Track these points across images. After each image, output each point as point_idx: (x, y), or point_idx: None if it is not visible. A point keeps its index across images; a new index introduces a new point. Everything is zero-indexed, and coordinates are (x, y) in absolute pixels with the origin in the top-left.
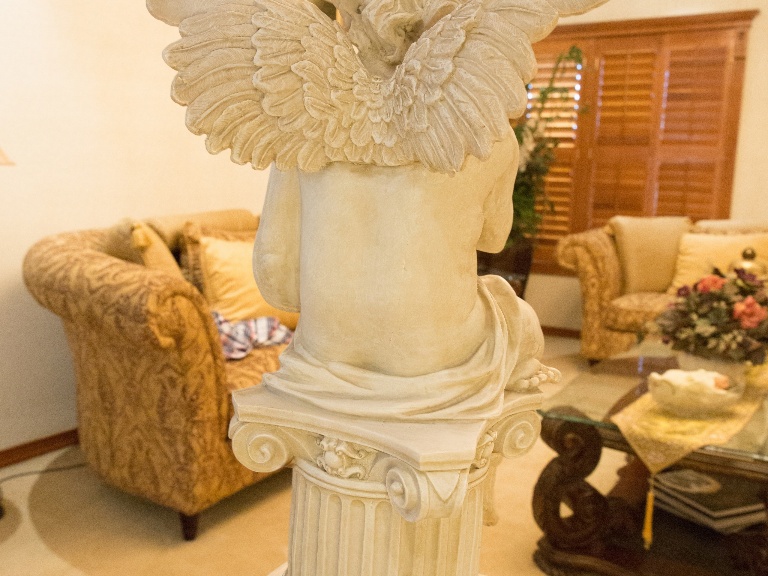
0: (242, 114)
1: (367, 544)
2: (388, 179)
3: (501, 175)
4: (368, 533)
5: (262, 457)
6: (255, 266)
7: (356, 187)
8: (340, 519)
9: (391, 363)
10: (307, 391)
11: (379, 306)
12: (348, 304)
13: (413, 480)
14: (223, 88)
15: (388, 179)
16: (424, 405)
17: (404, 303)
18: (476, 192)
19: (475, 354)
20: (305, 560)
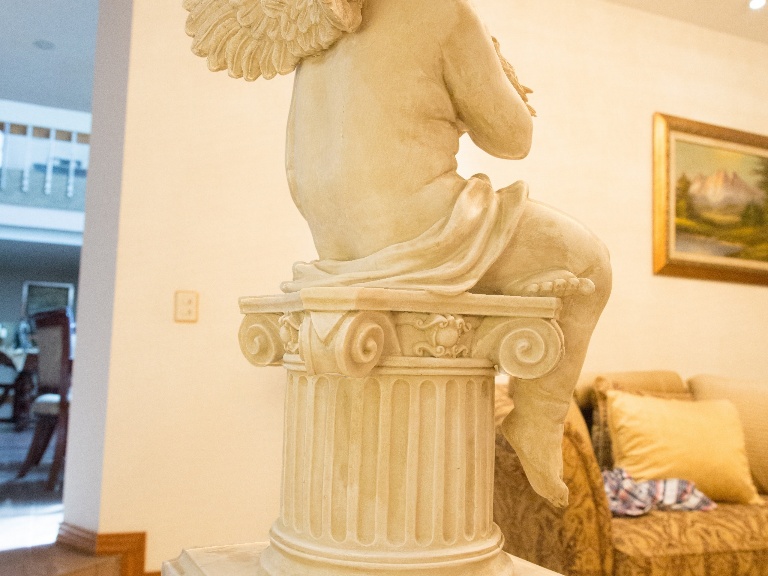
0: (227, 31)
1: (308, 424)
2: (333, 59)
3: (447, 38)
4: (309, 412)
5: (255, 348)
6: None
7: (314, 75)
8: None
9: (356, 246)
10: None
11: (330, 181)
12: (315, 188)
13: None
14: (215, 14)
15: (333, 59)
16: (364, 275)
17: (345, 172)
18: (410, 53)
19: None
20: None
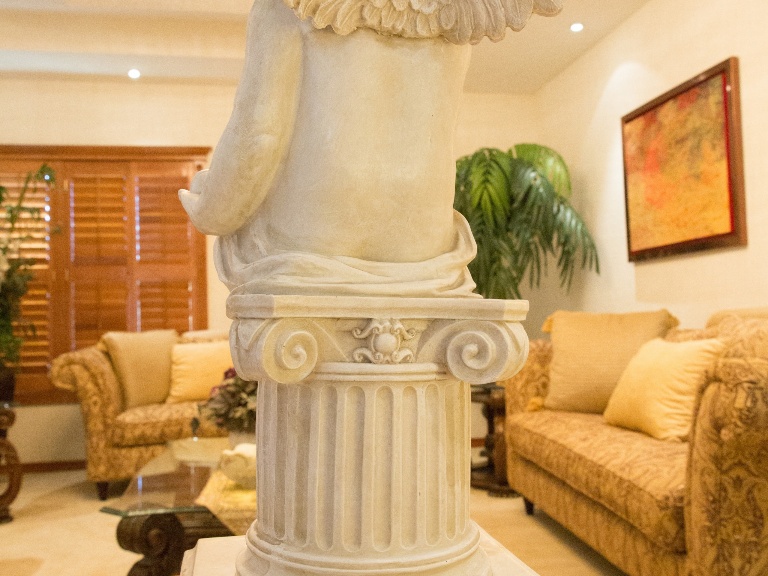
0: None
1: (421, 435)
2: (411, 51)
3: None
4: (421, 422)
5: (295, 361)
6: (235, 154)
7: (382, 56)
8: (391, 414)
9: (400, 249)
10: (327, 283)
11: (405, 180)
12: (373, 180)
13: (490, 336)
14: None
15: (411, 51)
16: (446, 283)
17: (429, 176)
18: None
19: (458, 241)
20: (342, 482)
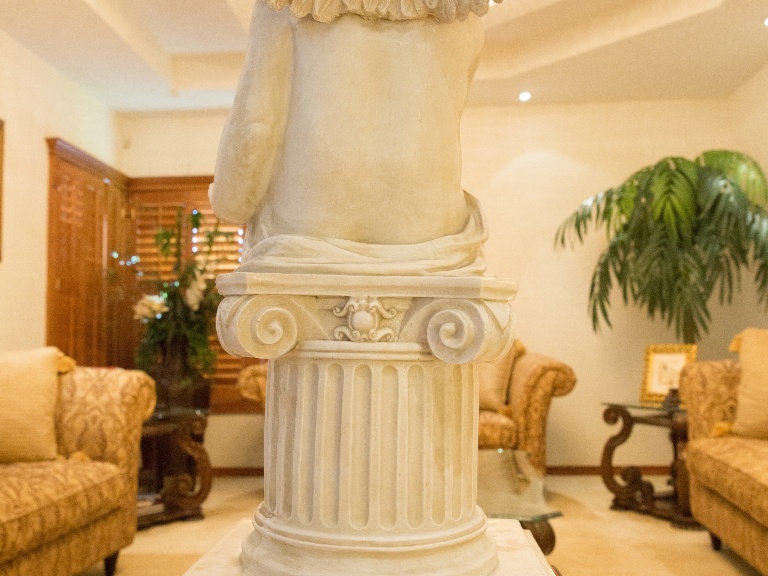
0: None
1: (402, 415)
2: (399, 34)
3: (477, 56)
4: (402, 402)
5: (271, 337)
6: (231, 143)
7: (368, 40)
8: (369, 392)
9: (395, 231)
10: (312, 263)
11: (393, 161)
12: (359, 162)
13: (468, 314)
14: None
15: (399, 34)
16: (440, 264)
17: (419, 157)
18: (468, 61)
19: (467, 224)
20: (321, 458)
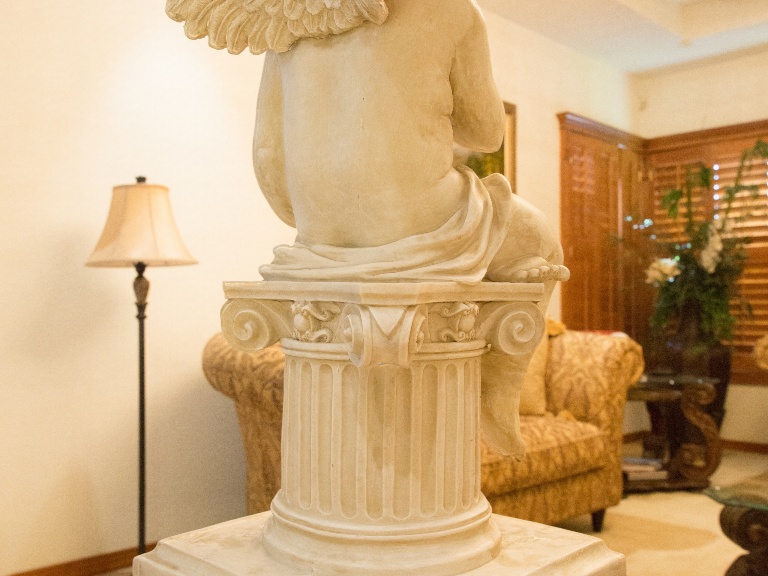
0: None
1: (335, 411)
2: (345, 45)
3: (461, 40)
4: (336, 399)
5: (246, 334)
6: (254, 167)
7: (319, 59)
8: (311, 388)
9: (364, 235)
10: (289, 269)
11: (343, 170)
12: (318, 174)
13: (360, 319)
14: None
15: (345, 45)
16: (389, 266)
17: (365, 163)
18: (431, 51)
19: (447, 221)
20: (287, 441)
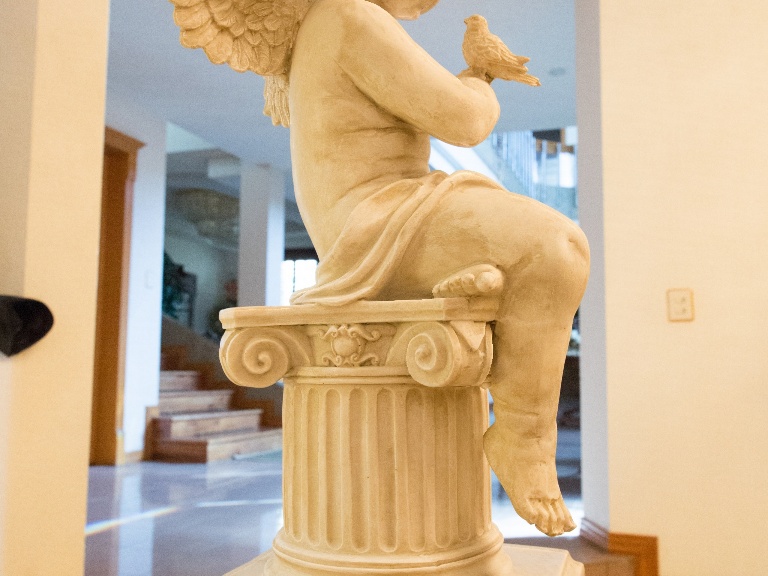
0: None
1: None
2: None
3: (340, 53)
4: None
5: None
6: None
7: None
8: None
9: None
10: None
11: None
12: None
13: None
14: None
15: None
16: (300, 292)
17: None
18: (313, 79)
19: None
20: None
